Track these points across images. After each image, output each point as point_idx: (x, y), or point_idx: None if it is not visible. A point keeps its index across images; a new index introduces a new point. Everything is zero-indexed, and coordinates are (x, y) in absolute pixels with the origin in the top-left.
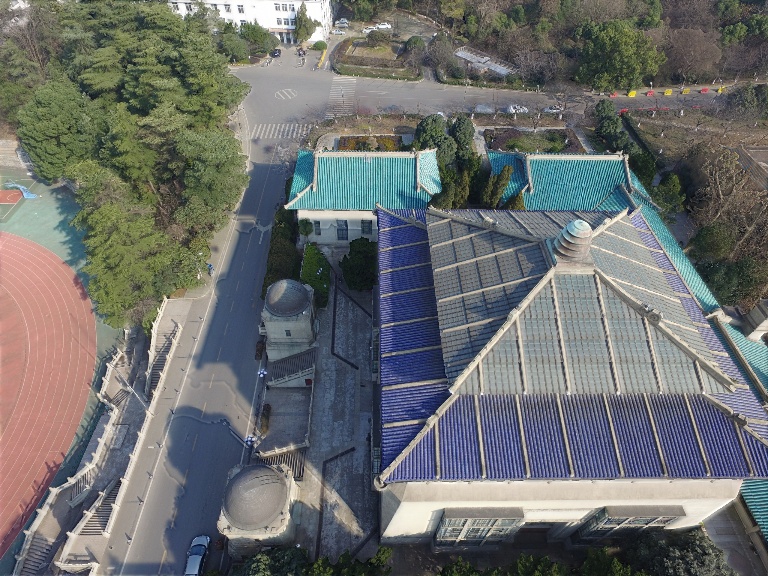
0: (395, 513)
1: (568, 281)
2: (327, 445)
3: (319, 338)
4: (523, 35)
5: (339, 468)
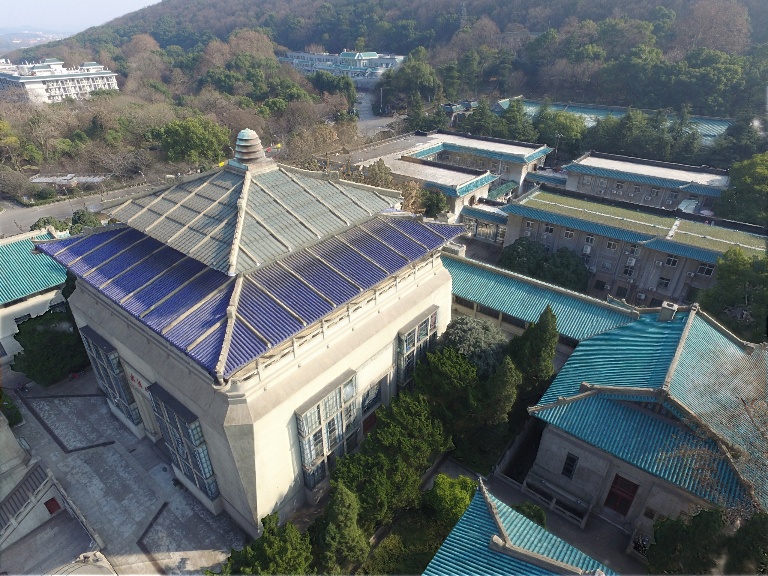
0: (254, 456)
1: (264, 178)
2: (129, 526)
3: (35, 452)
4: (97, 147)
5: (162, 531)
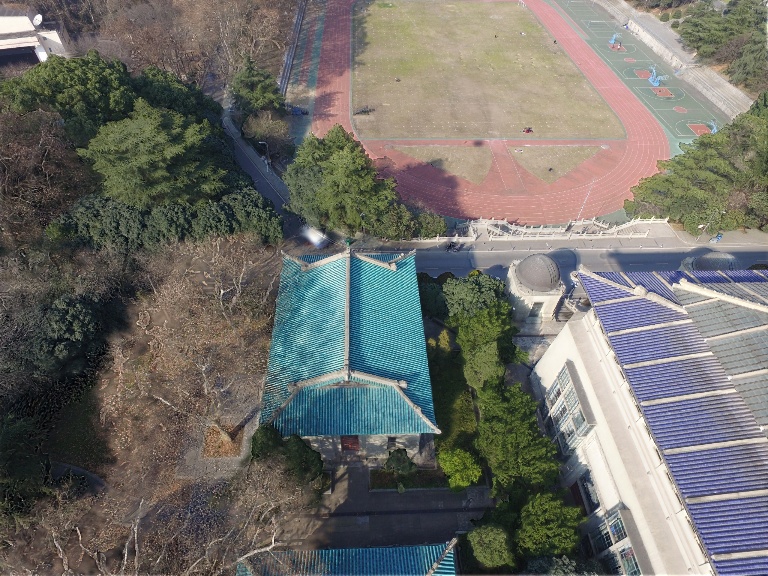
0: None
1: None
2: None
3: None
4: None
5: None
